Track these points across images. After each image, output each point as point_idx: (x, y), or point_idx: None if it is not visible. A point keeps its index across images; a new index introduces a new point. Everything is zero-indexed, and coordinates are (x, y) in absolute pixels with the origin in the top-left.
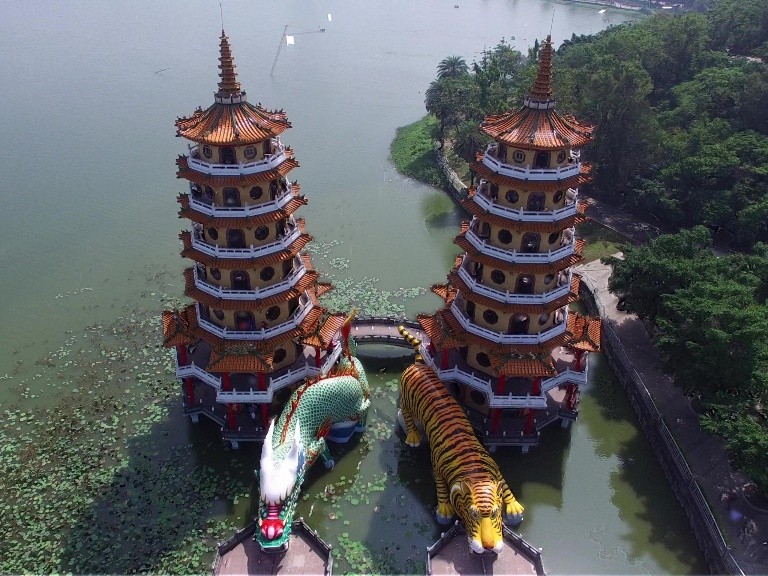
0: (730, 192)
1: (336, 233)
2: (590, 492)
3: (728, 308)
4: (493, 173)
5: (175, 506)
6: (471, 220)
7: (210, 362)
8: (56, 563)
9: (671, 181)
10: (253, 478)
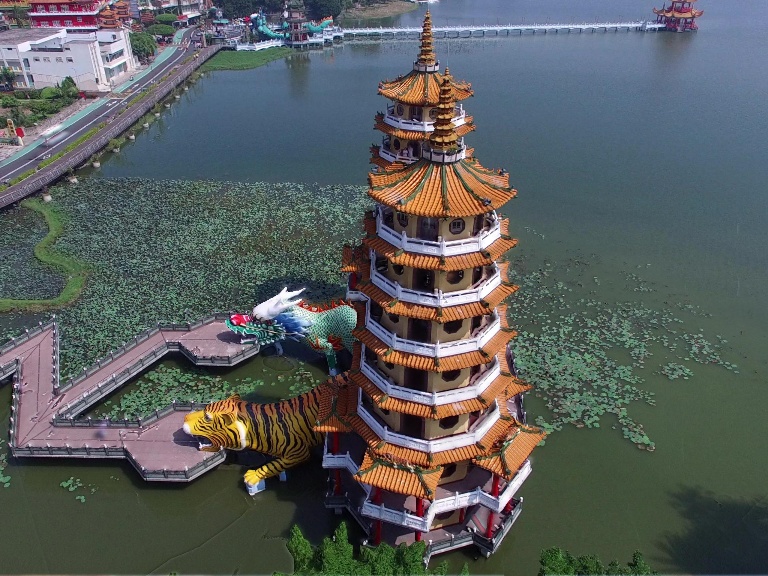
0: None
1: (759, 366)
2: (274, 565)
3: None
4: None
5: None
6: None
7: None
8: (271, 278)
9: None
10: None
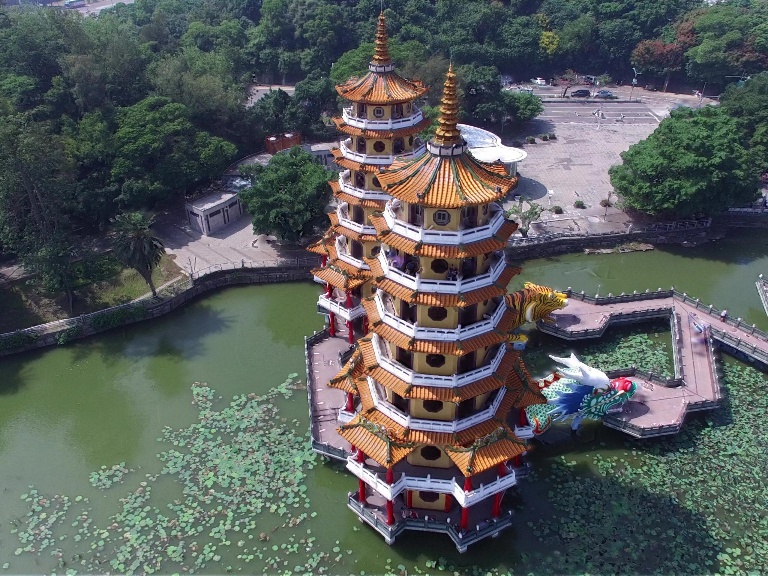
0: (179, 153)
1: None
2: None
3: None
4: (417, 126)
5: (606, 506)
6: (6, 358)
7: (536, 401)
8: (721, 575)
9: (133, 173)
10: (540, 462)
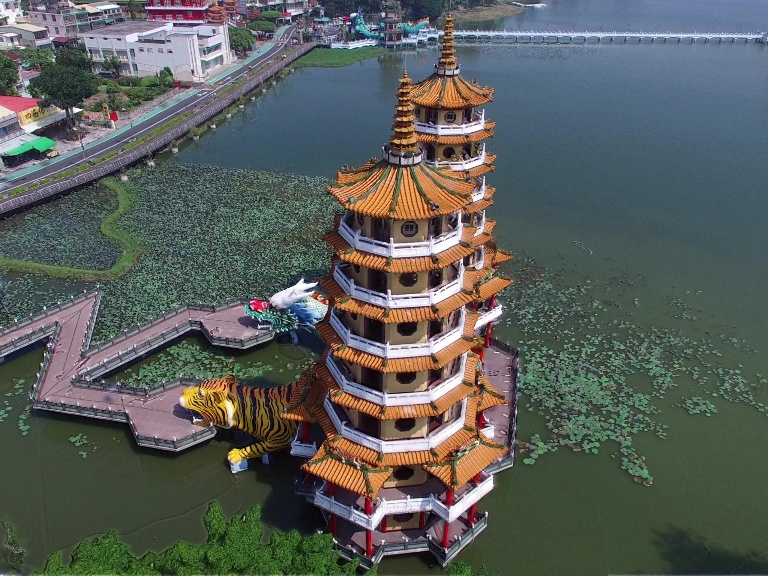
0: None
1: None
2: None
3: (252, 561)
4: None
5: None
6: None
7: None
8: (306, 269)
9: None
10: None
